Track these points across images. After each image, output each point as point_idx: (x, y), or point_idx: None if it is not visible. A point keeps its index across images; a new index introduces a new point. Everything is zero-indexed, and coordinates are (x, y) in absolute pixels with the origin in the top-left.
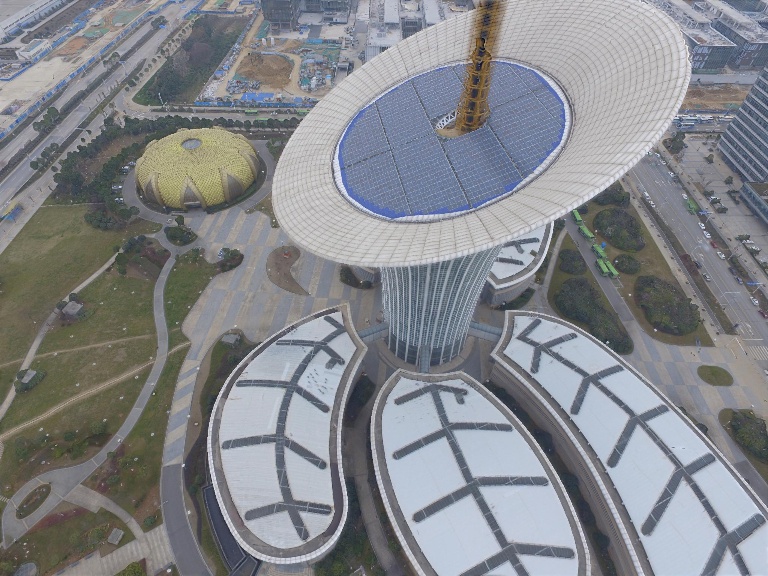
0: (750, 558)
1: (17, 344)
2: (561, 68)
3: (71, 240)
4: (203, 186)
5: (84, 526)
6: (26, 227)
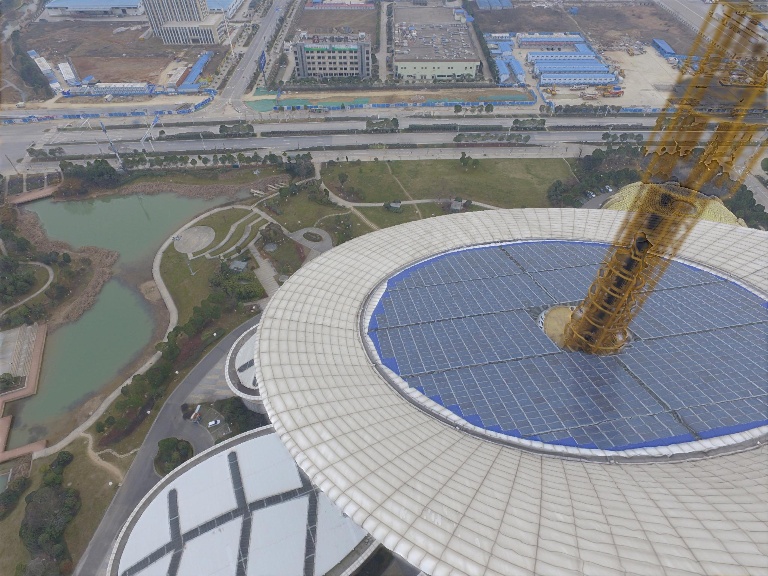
0: None
1: (424, 193)
2: (765, 456)
3: (528, 183)
4: None
5: (293, 263)
6: (536, 159)
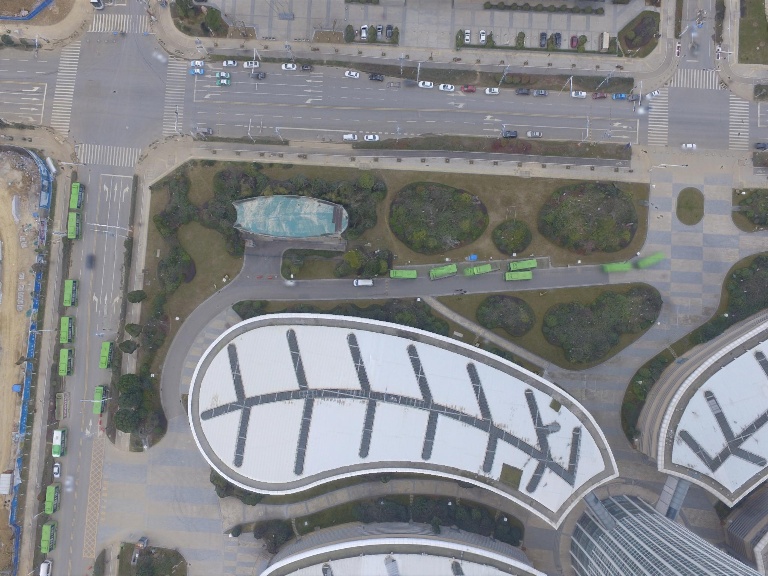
0: None
1: None
2: None
3: None
4: None
5: None
6: None
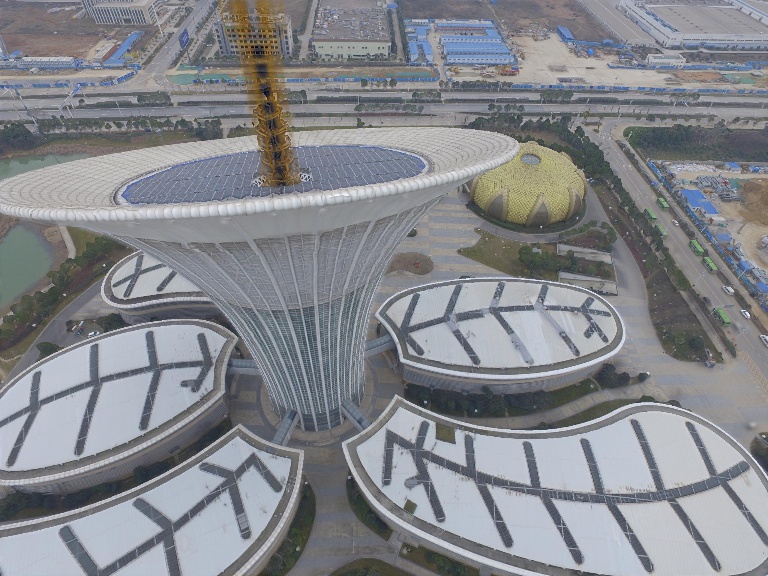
0: None
1: None
2: None
3: None
4: (482, 184)
5: None
6: None
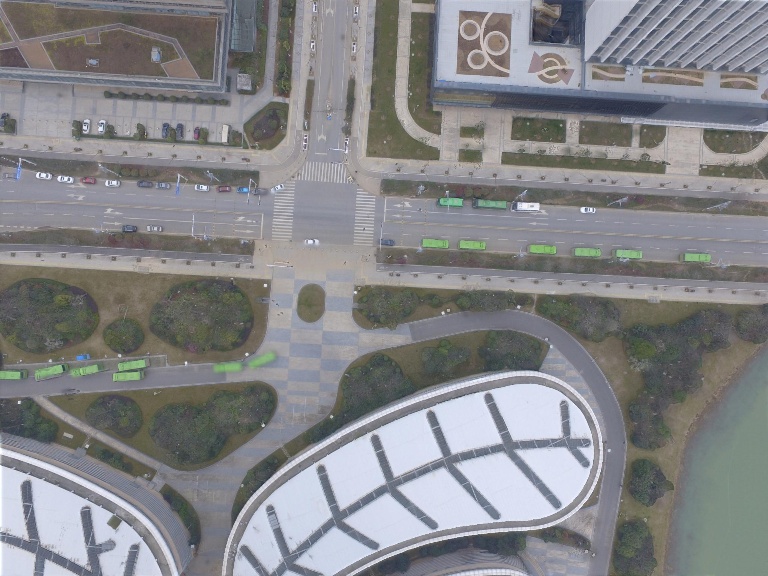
0: (523, 433)
1: None
2: None
3: None
4: None
5: None
6: None
